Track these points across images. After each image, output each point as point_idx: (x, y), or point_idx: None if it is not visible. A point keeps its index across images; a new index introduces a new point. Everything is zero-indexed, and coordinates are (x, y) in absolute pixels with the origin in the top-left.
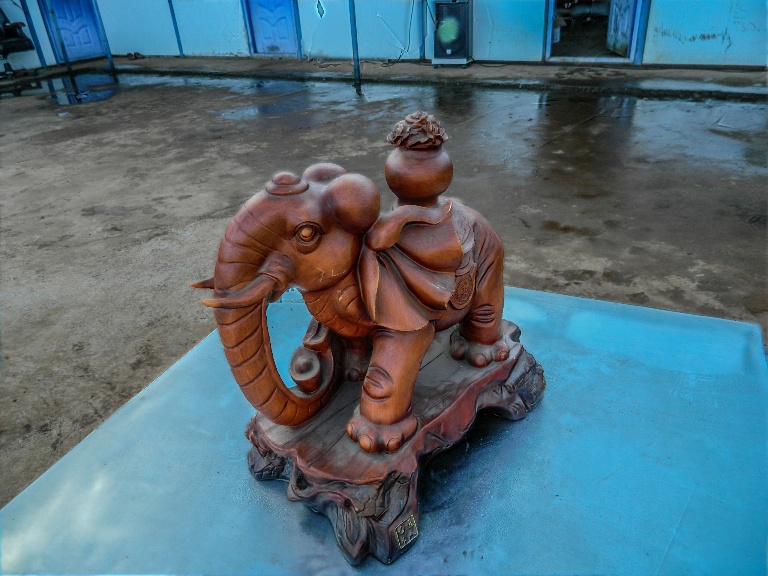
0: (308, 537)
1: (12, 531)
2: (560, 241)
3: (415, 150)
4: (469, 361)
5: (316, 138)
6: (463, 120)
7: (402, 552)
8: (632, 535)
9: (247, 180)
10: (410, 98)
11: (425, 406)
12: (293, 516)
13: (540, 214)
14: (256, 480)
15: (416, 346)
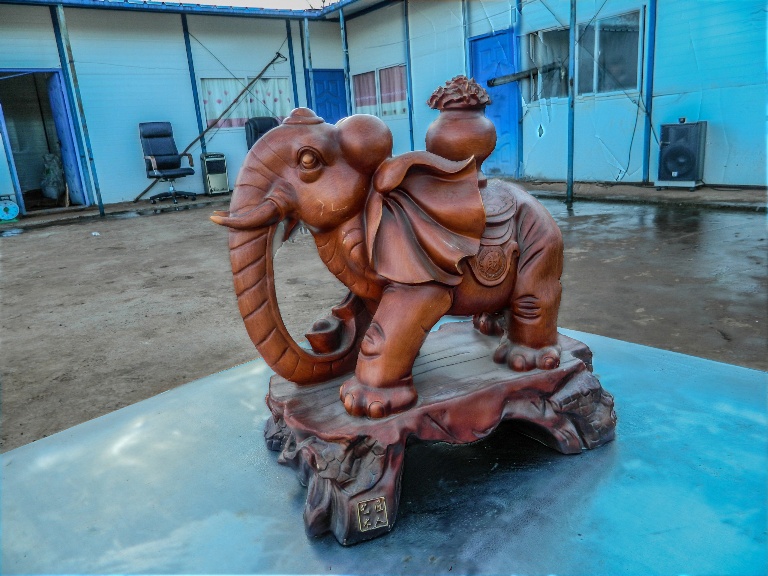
0: (283, 504)
1: (64, 442)
2: (767, 358)
3: (450, 110)
4: (508, 364)
5: None
6: (676, 236)
7: (364, 539)
8: None
9: None
10: (621, 214)
11: (436, 392)
12: (281, 484)
13: (747, 328)
14: (267, 449)
15: (418, 305)
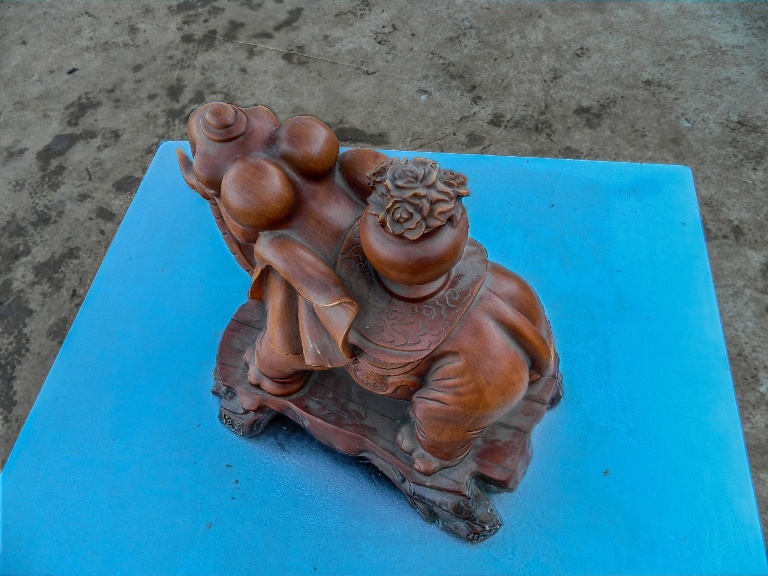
0: None
1: None
2: None
3: None
4: None
5: None
6: None
7: None
8: None
9: None
10: None
11: (321, 396)
12: None
13: None
14: None
15: (284, 355)
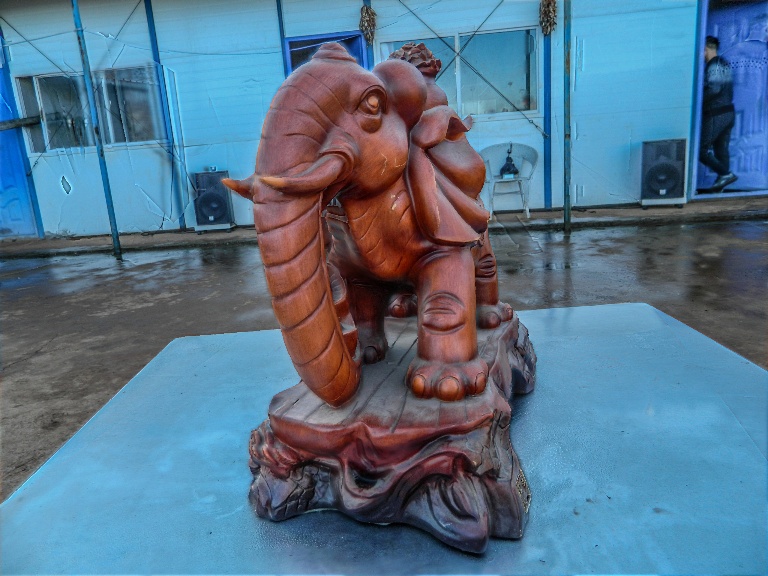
0: (396, 552)
1: None
2: None
3: None
4: (480, 325)
5: (86, 299)
6: (246, 268)
7: (525, 522)
8: (713, 437)
9: (6, 346)
10: (183, 258)
11: None
12: (358, 539)
13: None
14: (275, 523)
15: (472, 266)
